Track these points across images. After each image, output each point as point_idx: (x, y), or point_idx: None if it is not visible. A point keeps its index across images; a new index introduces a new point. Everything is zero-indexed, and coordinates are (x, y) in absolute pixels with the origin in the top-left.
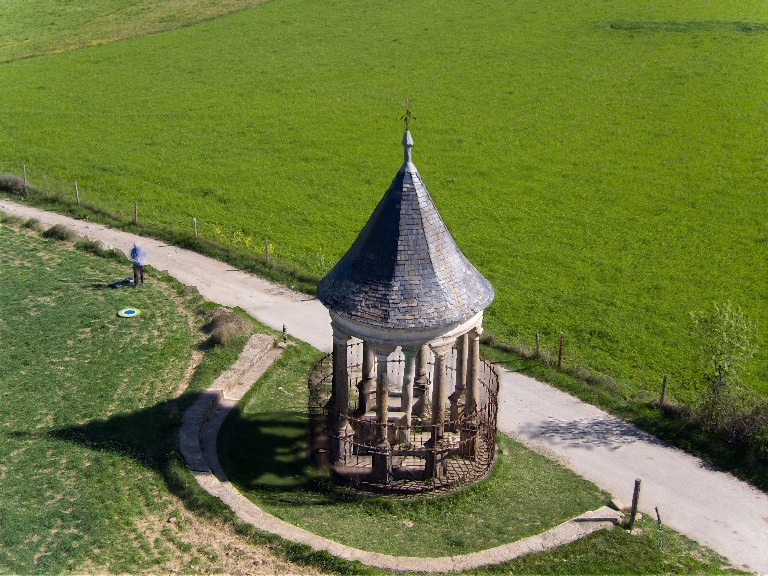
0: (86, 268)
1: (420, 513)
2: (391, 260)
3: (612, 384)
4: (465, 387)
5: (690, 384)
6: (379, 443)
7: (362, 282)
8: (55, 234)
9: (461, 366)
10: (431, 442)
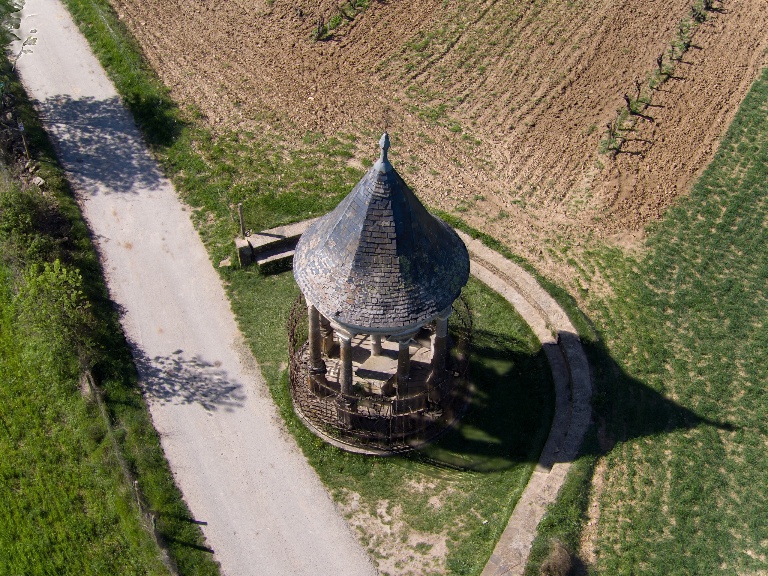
0: None
1: None
2: None
3: None
4: None
5: None
6: None
7: None
8: None
9: None
10: None
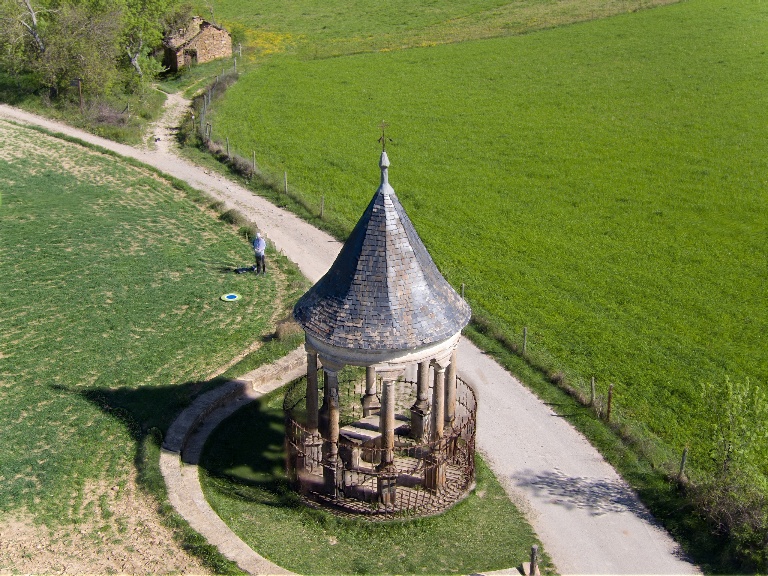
0: (231, 251)
1: (350, 533)
2: (349, 278)
3: (646, 448)
4: (451, 419)
5: (698, 462)
6: (329, 457)
7: (323, 296)
8: (228, 217)
9: (447, 397)
10: (379, 466)
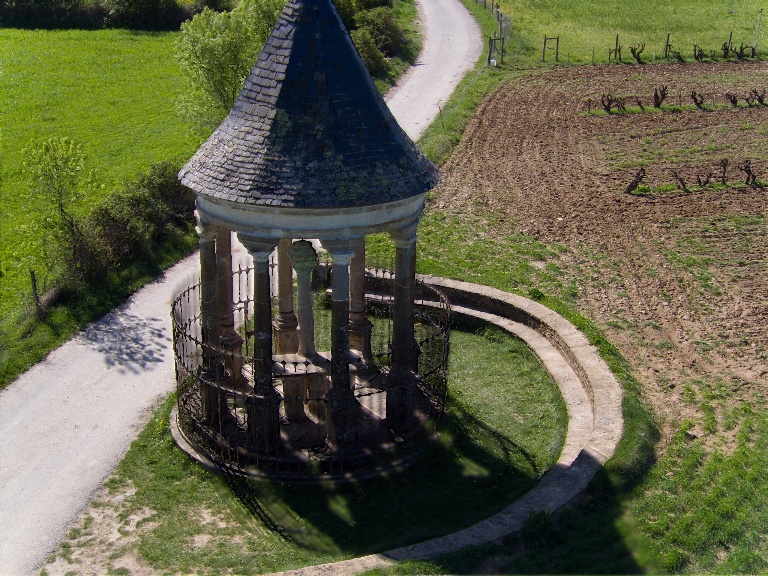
0: None
1: None
2: None
3: None
4: None
5: None
6: None
7: None
8: None
9: None
10: None
